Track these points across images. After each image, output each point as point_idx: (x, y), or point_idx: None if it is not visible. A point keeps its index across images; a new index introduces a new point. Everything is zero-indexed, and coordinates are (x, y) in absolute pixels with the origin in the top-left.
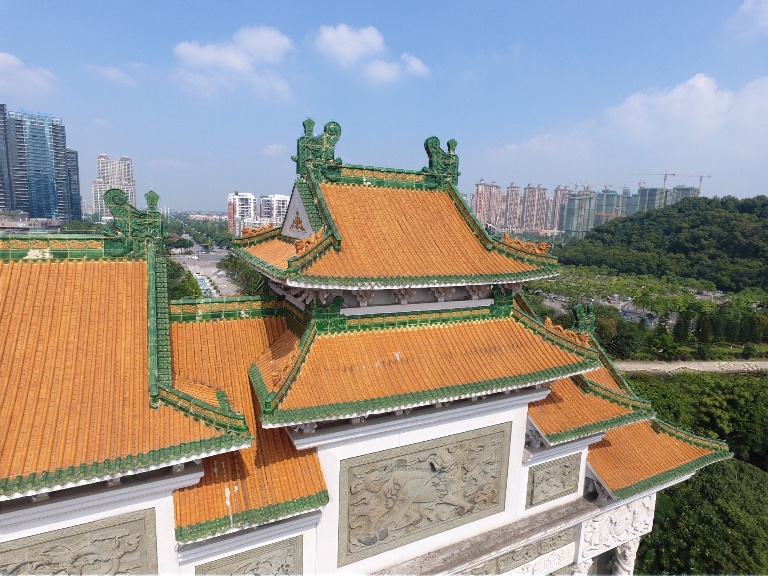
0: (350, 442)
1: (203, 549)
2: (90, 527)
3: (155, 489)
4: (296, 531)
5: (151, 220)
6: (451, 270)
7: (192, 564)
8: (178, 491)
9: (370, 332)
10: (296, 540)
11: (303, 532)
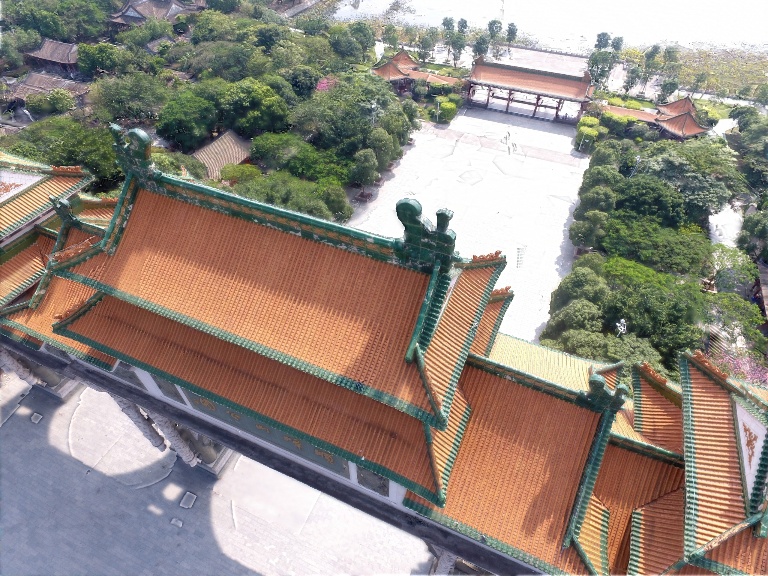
0: None
1: None
2: None
3: None
4: None
5: None
6: (29, 163)
7: None
8: None
9: None
10: None
11: None
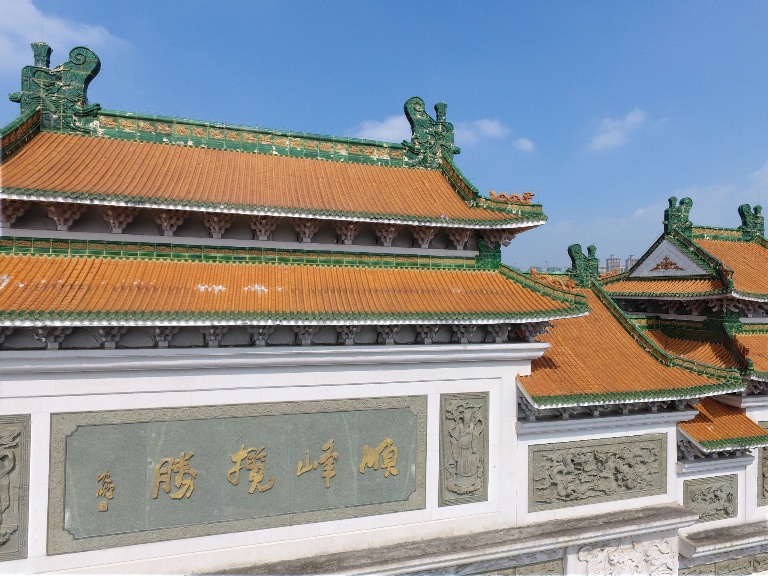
0: (763, 409)
1: (696, 465)
2: (639, 439)
3: (675, 418)
4: (734, 470)
5: (592, 263)
6: None
7: (682, 478)
8: (681, 423)
9: (756, 335)
10: (733, 477)
11: (738, 472)
